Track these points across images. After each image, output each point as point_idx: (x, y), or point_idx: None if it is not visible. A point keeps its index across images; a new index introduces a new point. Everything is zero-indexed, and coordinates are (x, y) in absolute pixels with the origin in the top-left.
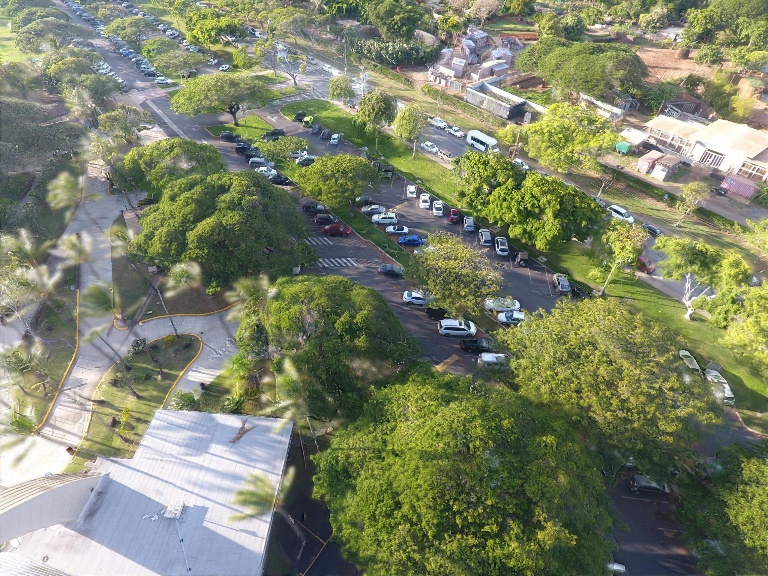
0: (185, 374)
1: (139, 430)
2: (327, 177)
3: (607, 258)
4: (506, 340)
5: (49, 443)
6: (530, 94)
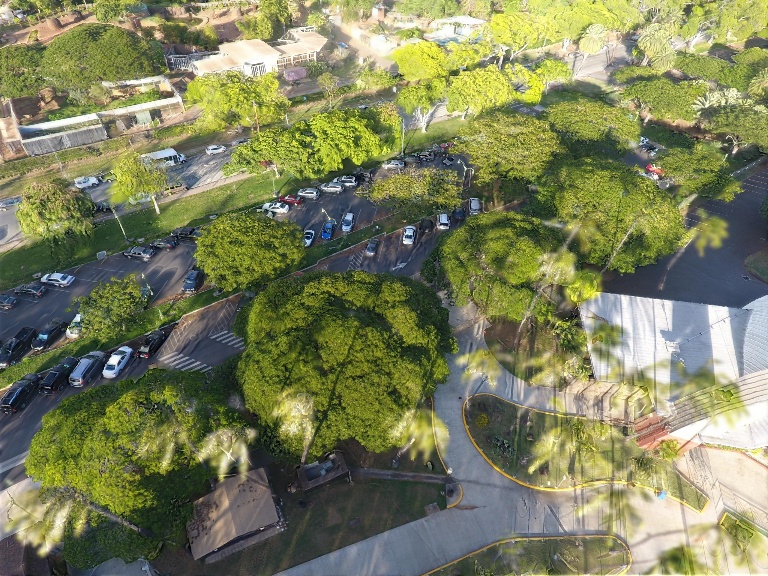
0: (518, 403)
1: (589, 429)
2: (265, 244)
3: (389, 132)
4: (491, 178)
5: (629, 518)
6: (67, 112)
